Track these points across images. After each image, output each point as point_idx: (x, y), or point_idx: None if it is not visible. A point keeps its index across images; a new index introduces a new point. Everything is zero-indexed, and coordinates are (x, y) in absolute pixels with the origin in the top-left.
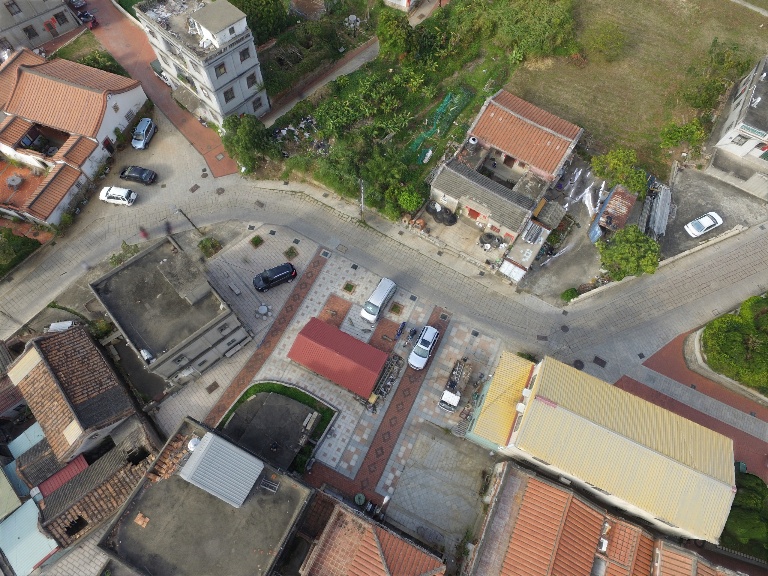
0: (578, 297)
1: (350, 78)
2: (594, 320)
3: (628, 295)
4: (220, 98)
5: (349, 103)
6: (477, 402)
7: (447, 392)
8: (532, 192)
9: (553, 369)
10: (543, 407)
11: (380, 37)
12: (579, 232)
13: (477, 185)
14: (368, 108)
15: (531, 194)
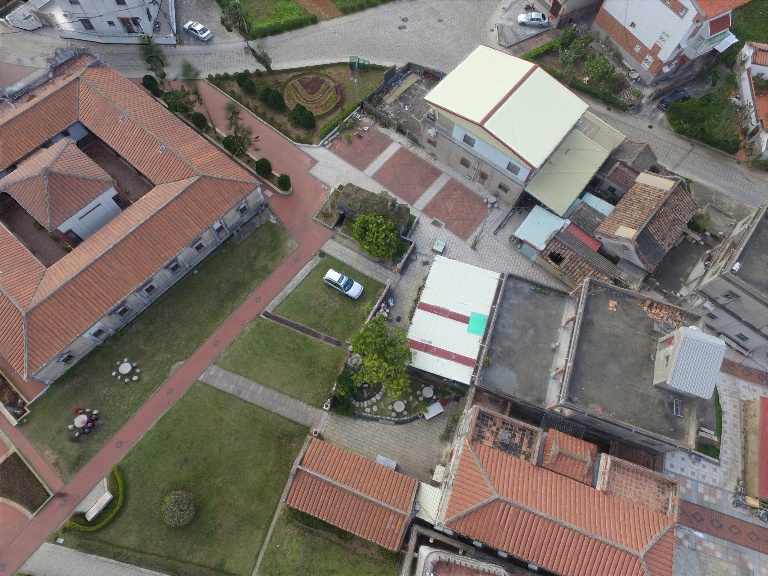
0: None
1: None
2: None
3: None
4: None
5: None
6: None
7: None
8: None
9: None
10: None
11: None
12: None
13: None
14: None
15: None
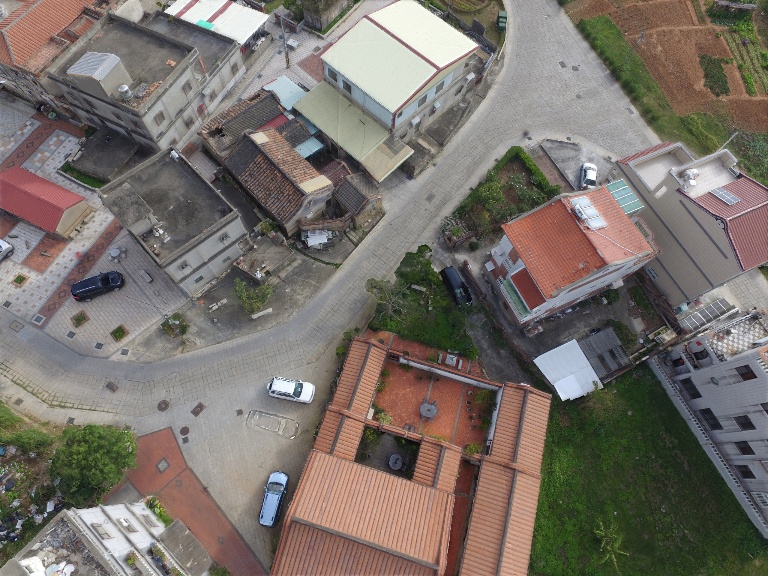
0: None
1: None
2: None
3: None
4: None
5: None
6: None
7: None
8: None
9: None
10: None
11: None
12: None
13: None
14: None
15: None
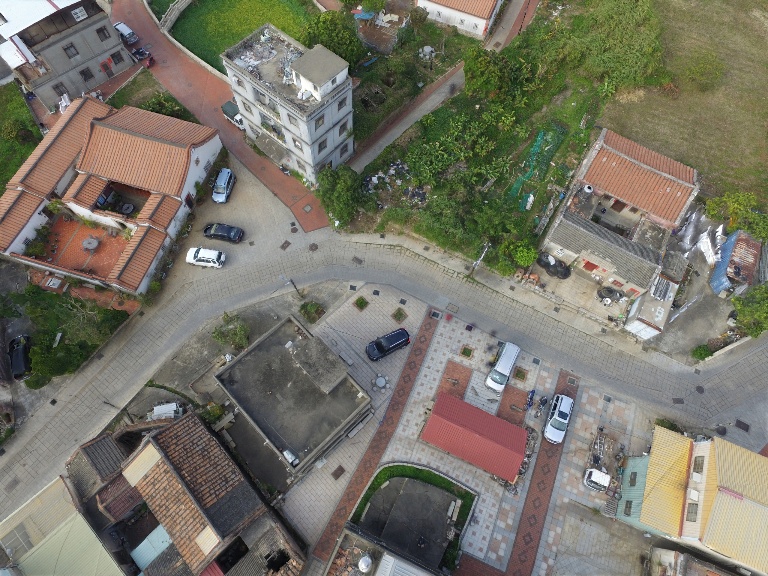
0: (712, 355)
1: (435, 117)
2: (729, 379)
3: (760, 349)
4: (314, 150)
5: (443, 147)
6: (623, 477)
7: (596, 471)
8: (653, 242)
9: (727, 452)
10: (728, 499)
11: (469, 73)
12: (699, 281)
13: (599, 238)
14: (463, 152)
15: (652, 244)
